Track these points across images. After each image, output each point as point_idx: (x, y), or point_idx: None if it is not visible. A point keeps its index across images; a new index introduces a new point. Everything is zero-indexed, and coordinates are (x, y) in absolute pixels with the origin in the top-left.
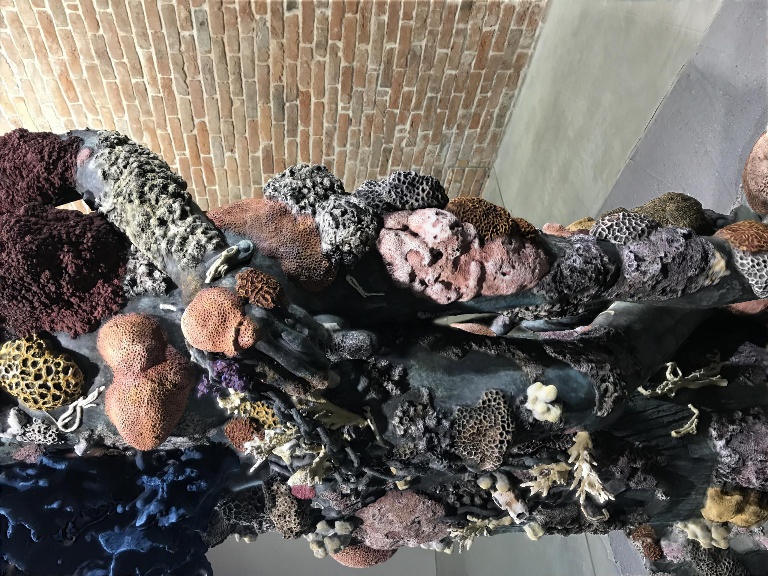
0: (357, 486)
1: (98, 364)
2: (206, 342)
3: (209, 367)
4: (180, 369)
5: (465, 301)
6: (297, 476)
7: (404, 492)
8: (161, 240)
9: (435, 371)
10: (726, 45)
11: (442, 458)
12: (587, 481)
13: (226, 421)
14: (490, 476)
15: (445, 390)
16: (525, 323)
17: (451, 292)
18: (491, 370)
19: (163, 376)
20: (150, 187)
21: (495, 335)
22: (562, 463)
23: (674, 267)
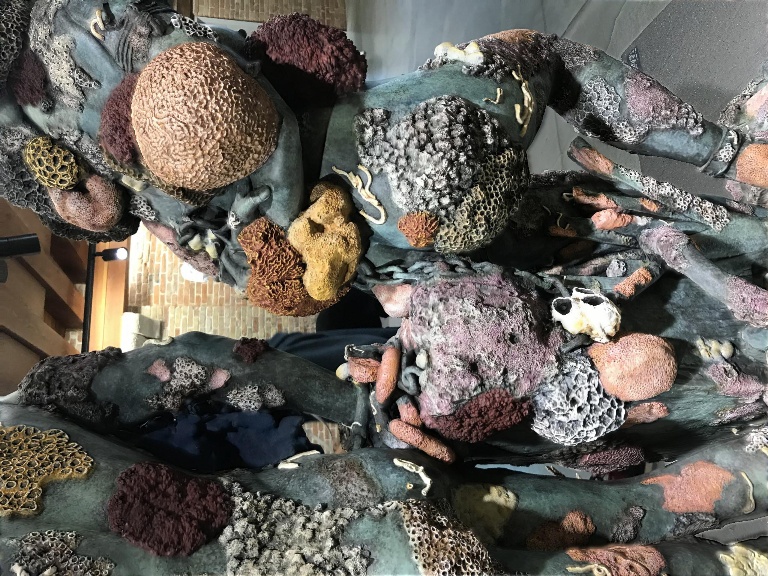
0: None
1: None
2: None
3: None
4: None
5: None
6: None
7: None
8: None
9: None
10: None
11: None
12: None
13: None
14: None
15: None
16: (745, 339)
17: None
18: None
19: None
20: None
21: (667, 391)
22: None
23: None
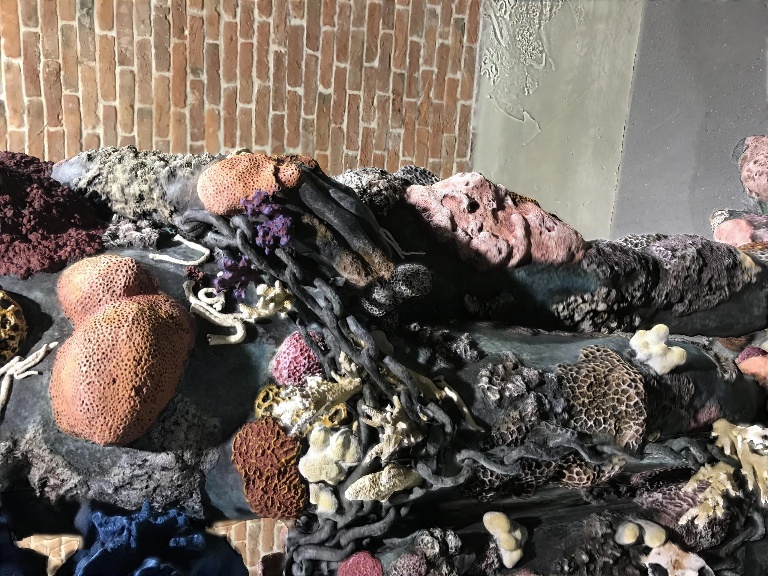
0: (456, 481)
1: (52, 316)
2: (235, 184)
3: (238, 218)
4: (178, 306)
5: (517, 261)
6: (359, 481)
7: (517, 574)
8: (161, 171)
9: (509, 341)
10: None
11: (564, 427)
12: (764, 471)
13: (234, 432)
14: (631, 522)
15: (531, 354)
16: None
17: (500, 240)
18: (575, 340)
19: (155, 304)
20: (145, 153)
21: None
22: (717, 464)
23: (707, 253)
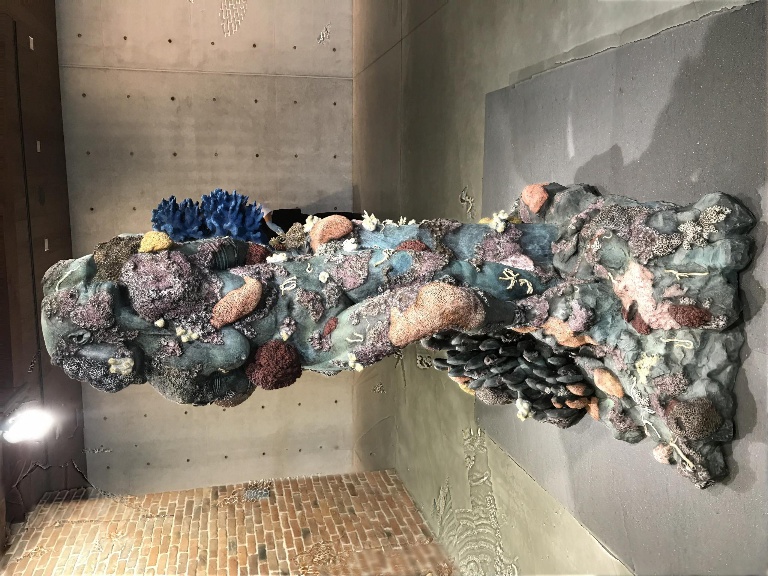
0: None
1: None
2: None
3: None
4: None
5: None
6: None
7: None
8: None
9: None
10: (562, 483)
11: None
12: None
13: None
14: None
15: None
16: None
17: None
18: None
19: None
20: None
21: None
22: None
23: None
